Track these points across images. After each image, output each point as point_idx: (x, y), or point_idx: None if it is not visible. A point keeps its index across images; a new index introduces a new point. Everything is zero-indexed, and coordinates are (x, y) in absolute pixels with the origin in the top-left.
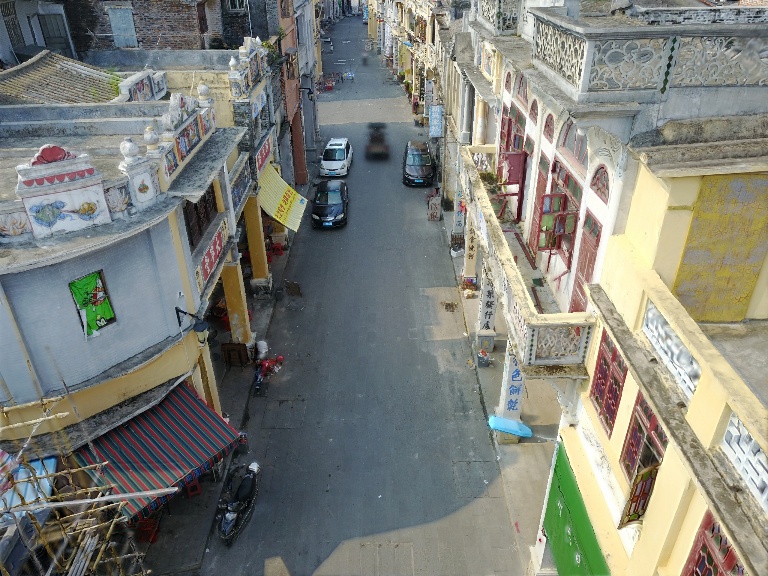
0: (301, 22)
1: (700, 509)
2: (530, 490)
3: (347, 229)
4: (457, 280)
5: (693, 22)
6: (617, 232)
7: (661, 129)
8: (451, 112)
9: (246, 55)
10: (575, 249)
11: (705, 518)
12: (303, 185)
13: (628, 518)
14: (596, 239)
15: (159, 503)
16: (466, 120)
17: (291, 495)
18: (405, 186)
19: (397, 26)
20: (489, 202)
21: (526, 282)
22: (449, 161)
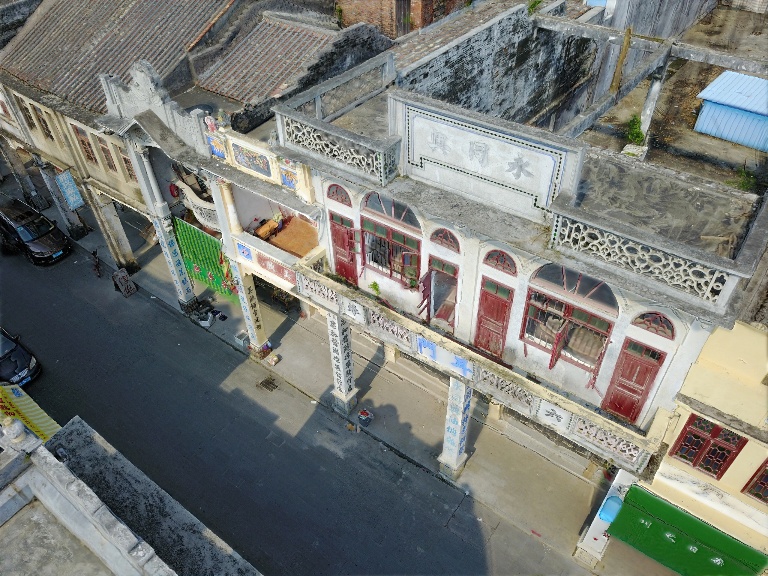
0: None
1: None
2: (511, 498)
3: (49, 370)
4: (241, 351)
5: (435, 68)
6: None
7: None
8: (88, 174)
9: None
10: (606, 362)
11: None
12: None
13: None
14: (658, 362)
15: None
16: (158, 192)
17: None
18: (42, 267)
19: None
20: (436, 333)
21: None
22: (111, 225)
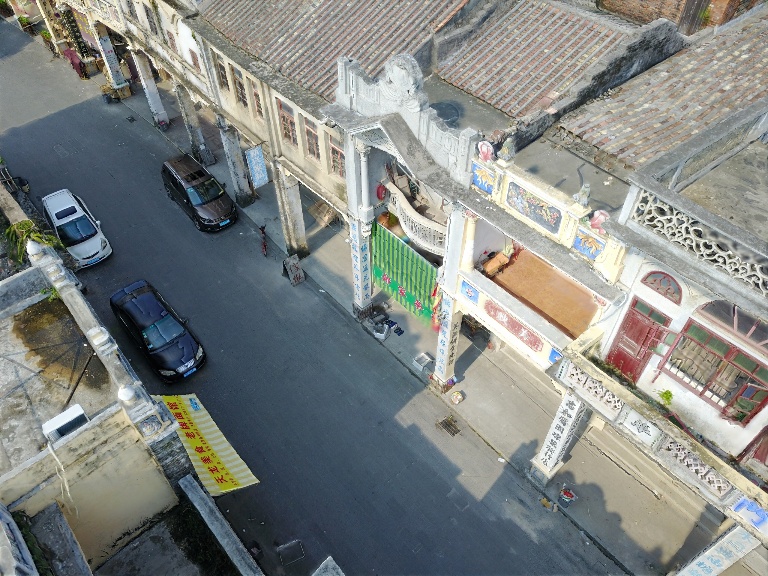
0: None
1: None
2: None
3: (214, 360)
4: (419, 377)
5: None
6: None
7: None
8: (281, 152)
9: None
10: None
11: None
12: None
13: None
14: None
15: None
16: (367, 195)
17: None
18: (207, 234)
19: None
20: None
21: None
22: (292, 208)
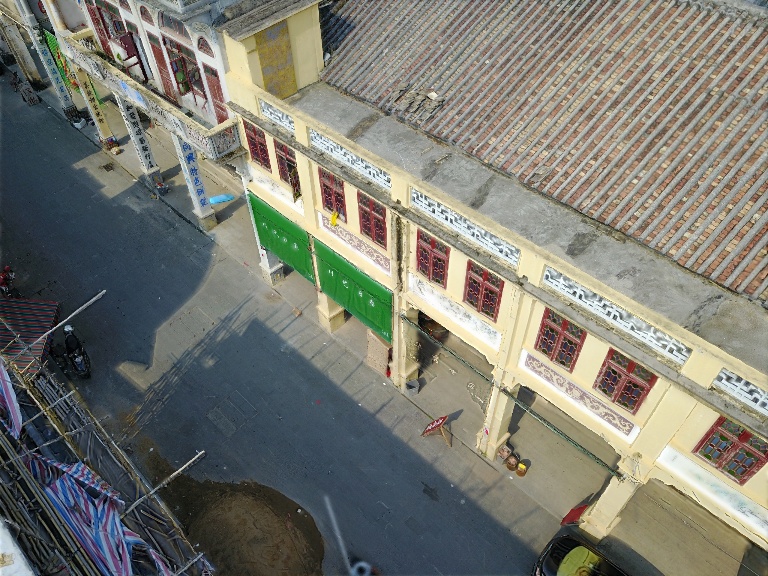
0: None
1: (316, 172)
2: (241, 244)
3: None
4: (97, 145)
5: None
6: (227, 71)
7: (224, 13)
8: None
9: None
10: (205, 87)
11: (319, 174)
12: None
13: (296, 196)
14: (217, 78)
15: (44, 361)
16: (24, 4)
17: (103, 332)
18: None
19: None
20: (126, 76)
21: None
22: (16, 44)
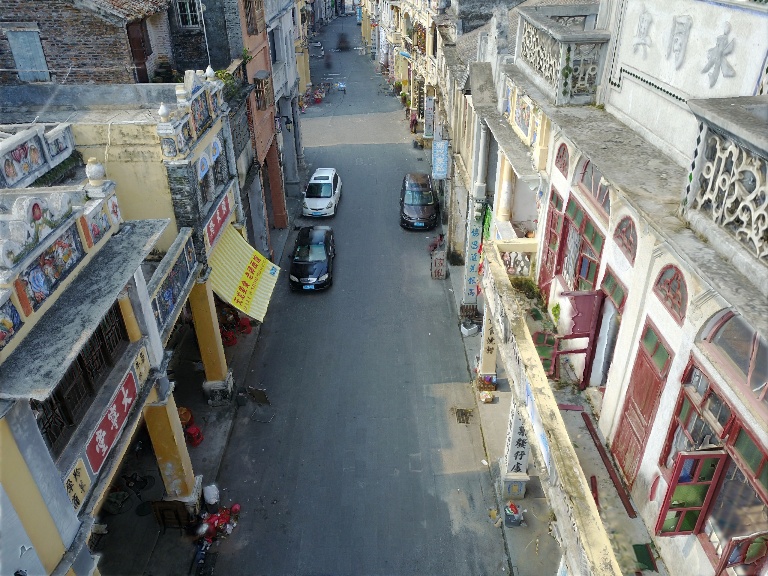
0: (278, 35)
1: None
2: None
3: (333, 292)
4: (470, 372)
5: None
6: None
7: None
8: (459, 150)
9: (186, 97)
10: None
11: None
12: (282, 229)
13: None
14: None
15: None
16: (481, 169)
17: None
18: (403, 229)
19: (393, 32)
20: (545, 377)
21: (623, 555)
22: (457, 208)
